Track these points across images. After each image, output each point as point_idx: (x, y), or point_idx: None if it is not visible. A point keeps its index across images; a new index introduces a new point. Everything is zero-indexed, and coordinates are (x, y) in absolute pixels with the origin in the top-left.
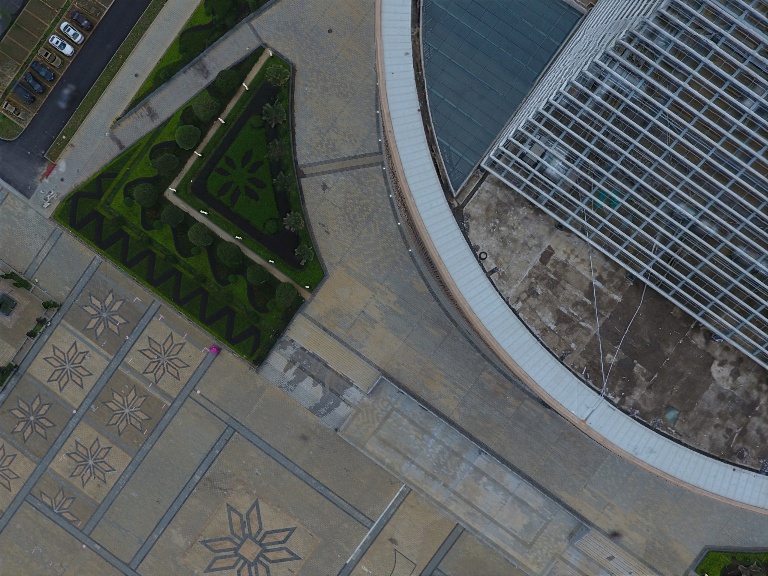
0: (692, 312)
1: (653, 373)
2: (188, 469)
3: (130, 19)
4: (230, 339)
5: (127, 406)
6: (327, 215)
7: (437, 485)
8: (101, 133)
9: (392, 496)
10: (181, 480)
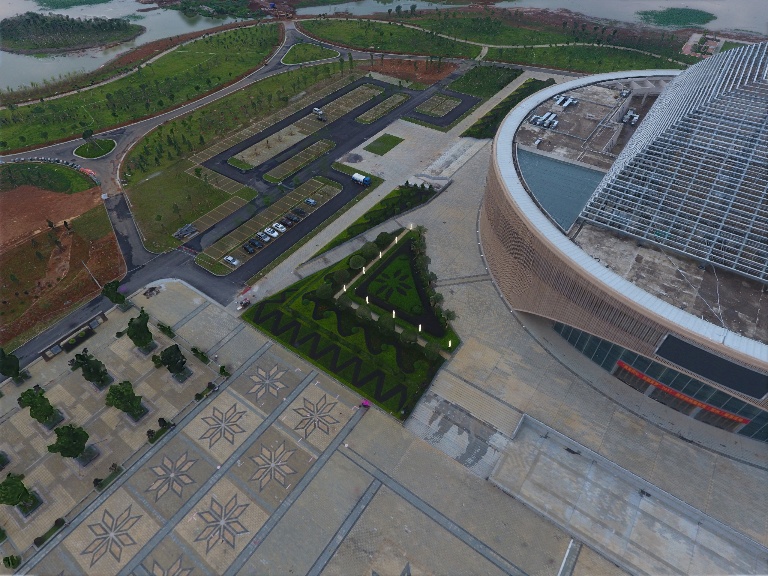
0: (755, 276)
1: (754, 318)
2: (330, 528)
3: (317, 223)
4: (379, 397)
5: (274, 460)
6: (456, 307)
7: (609, 533)
8: (288, 272)
9: (562, 555)
10: (321, 542)
